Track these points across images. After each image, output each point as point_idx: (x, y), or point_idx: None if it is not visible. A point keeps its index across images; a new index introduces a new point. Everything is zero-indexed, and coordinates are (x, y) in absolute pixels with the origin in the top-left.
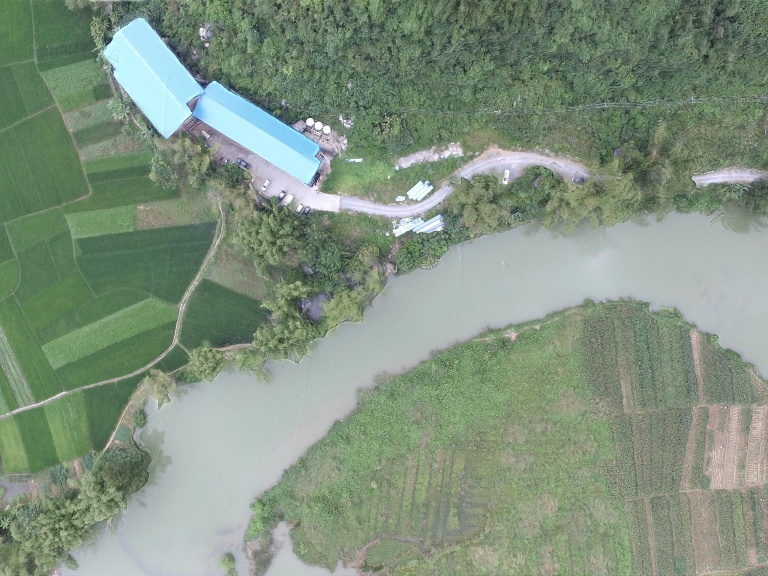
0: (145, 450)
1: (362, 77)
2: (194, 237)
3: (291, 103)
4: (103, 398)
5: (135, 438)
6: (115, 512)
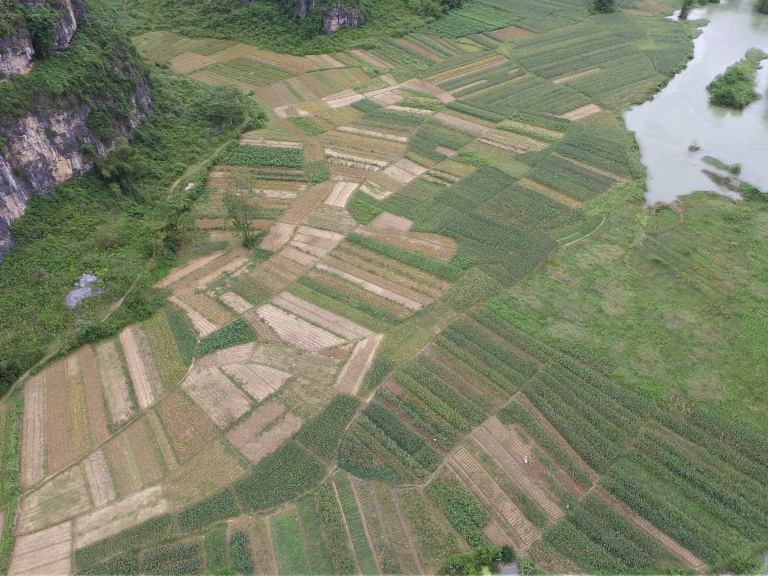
0: None
1: None
2: None
3: None
4: None
5: None
6: None
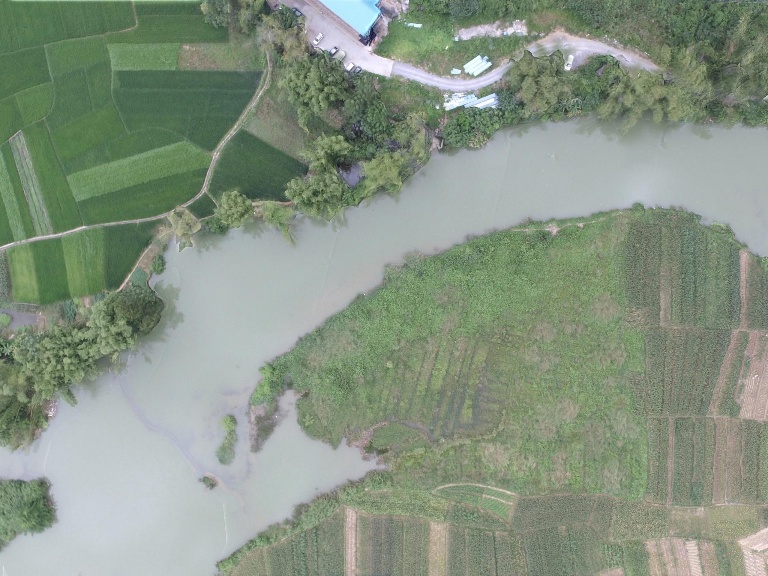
0: (159, 297)
1: None
2: (237, 84)
3: None
4: (123, 237)
5: (150, 284)
6: (122, 347)
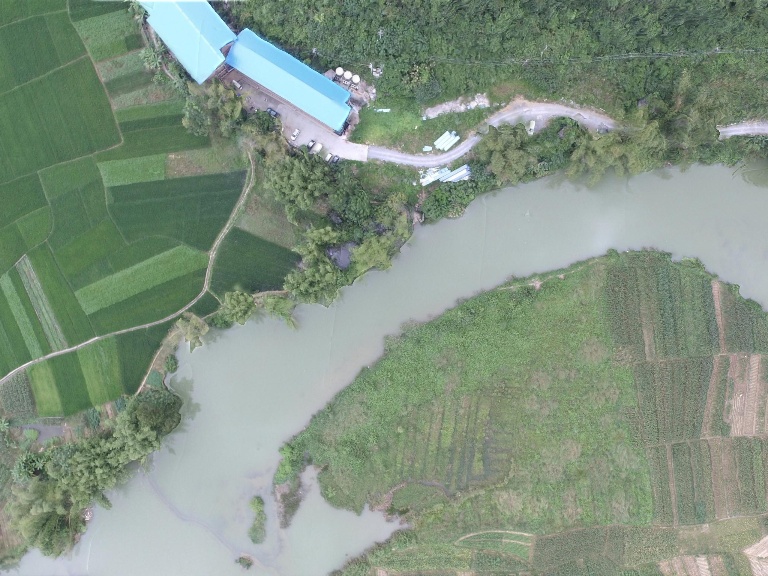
0: (176, 395)
1: (392, 25)
2: (224, 186)
3: (321, 51)
4: (135, 343)
5: (166, 383)
6: (149, 451)
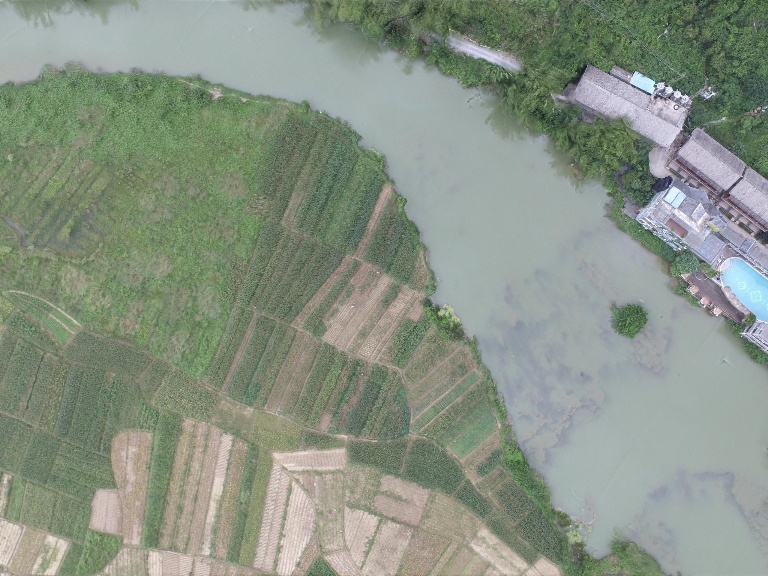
0: None
1: None
2: None
3: None
4: None
5: None
6: None
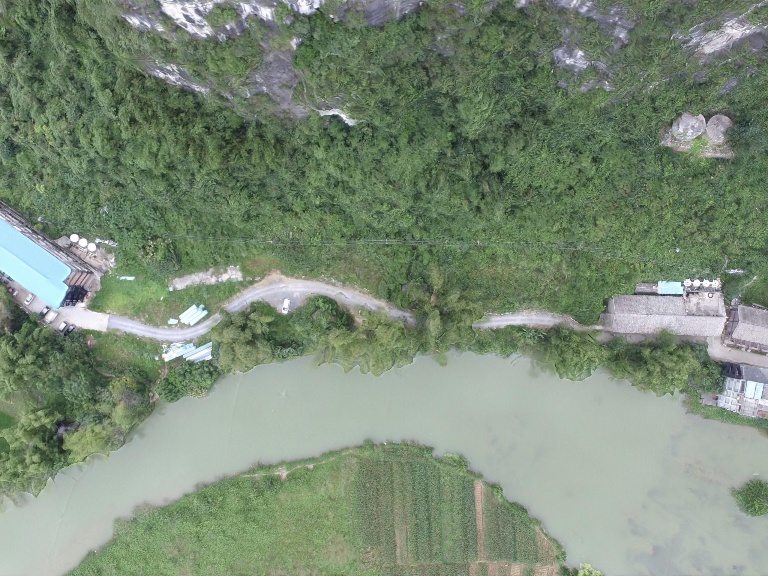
0: None
1: (119, 200)
2: None
3: (50, 219)
4: None
5: None
6: None
